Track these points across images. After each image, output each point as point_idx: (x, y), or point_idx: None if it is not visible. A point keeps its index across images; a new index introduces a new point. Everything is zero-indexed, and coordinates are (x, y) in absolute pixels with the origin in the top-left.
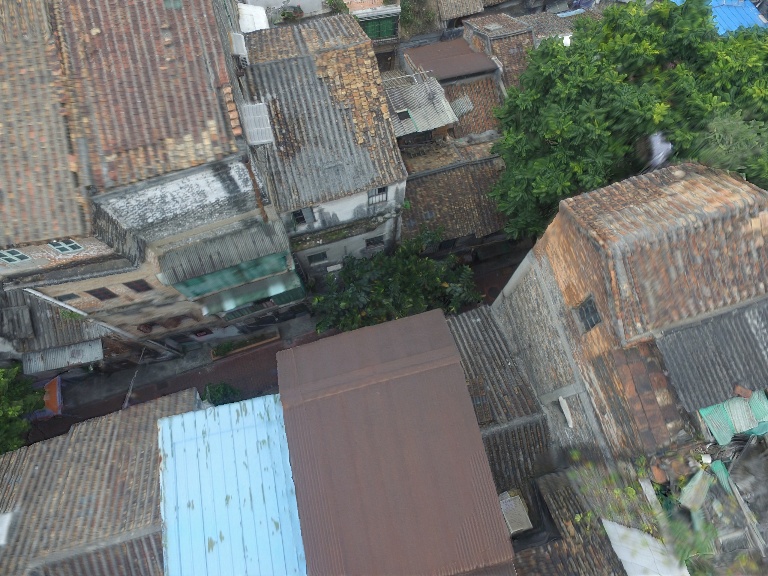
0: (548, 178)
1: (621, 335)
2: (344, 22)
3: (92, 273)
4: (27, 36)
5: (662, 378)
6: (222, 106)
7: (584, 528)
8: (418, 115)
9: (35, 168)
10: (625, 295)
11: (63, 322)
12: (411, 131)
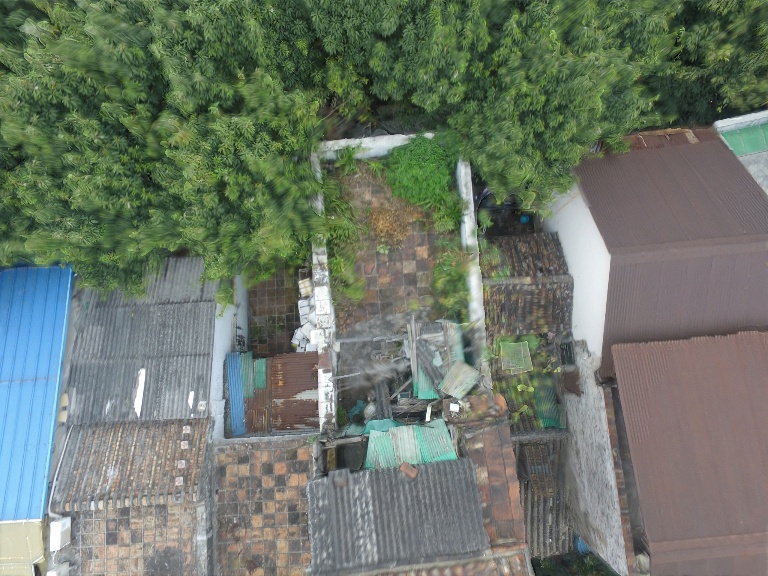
0: None
1: None
2: None
3: None
4: None
5: None
6: None
7: None
8: None
9: None
10: None
11: None
12: None
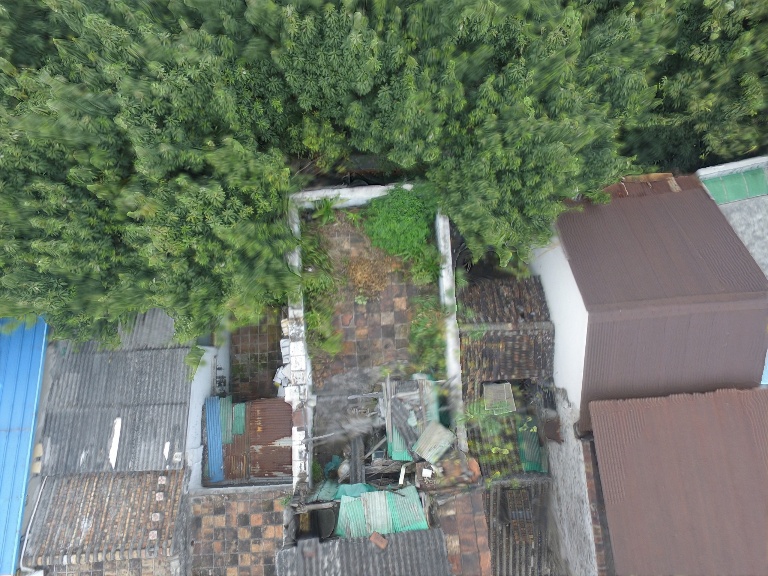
0: None
1: None
2: None
3: None
4: None
5: None
6: None
7: None
8: None
9: None
10: None
11: None
12: None
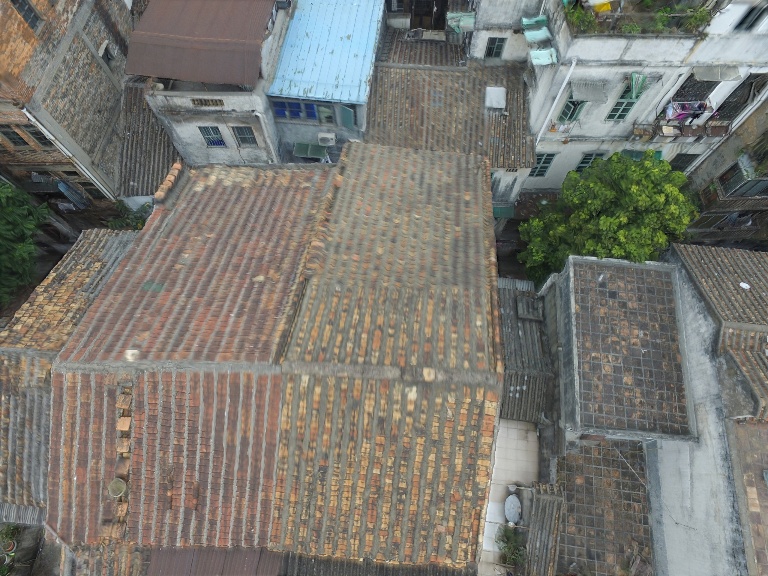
0: None
1: None
2: (3, 458)
3: None
4: (335, 288)
5: None
6: None
7: None
8: None
9: (375, 186)
10: None
11: None
12: None
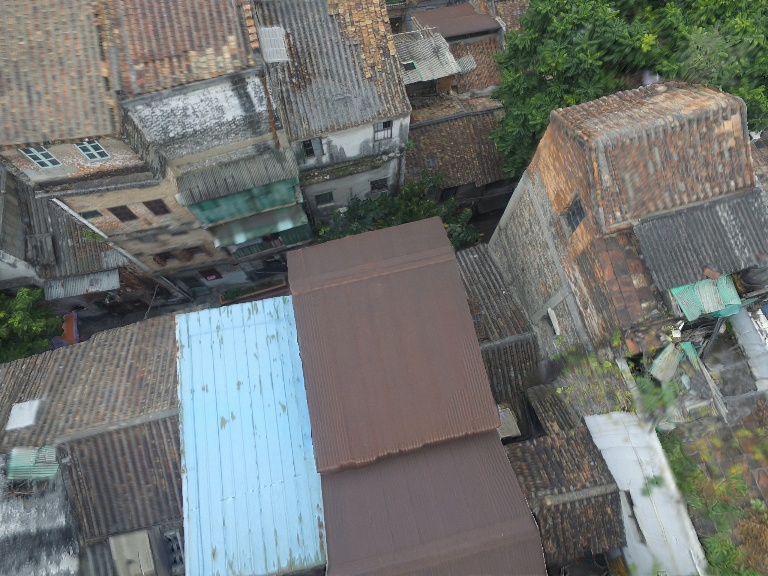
0: (543, 111)
1: (602, 222)
2: None
3: (116, 184)
4: None
5: (639, 264)
6: (241, 23)
7: (568, 427)
8: (423, 66)
9: (70, 73)
10: (606, 185)
11: (83, 251)
12: (416, 80)
